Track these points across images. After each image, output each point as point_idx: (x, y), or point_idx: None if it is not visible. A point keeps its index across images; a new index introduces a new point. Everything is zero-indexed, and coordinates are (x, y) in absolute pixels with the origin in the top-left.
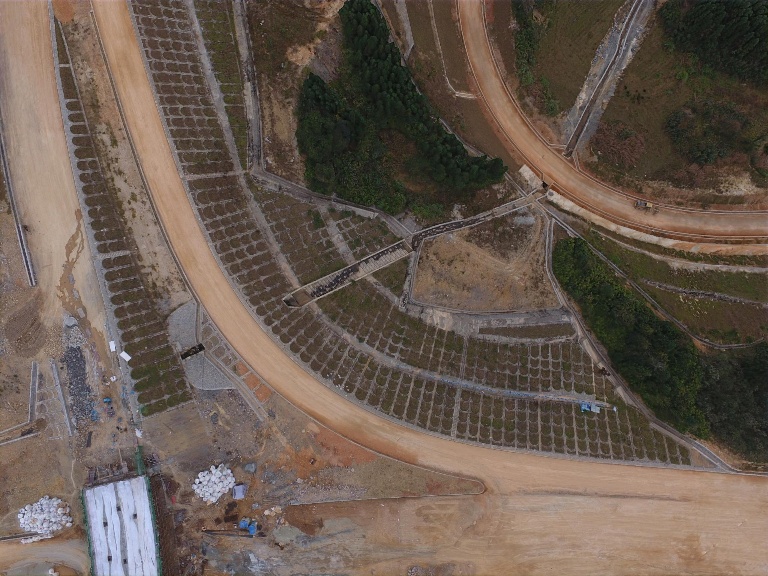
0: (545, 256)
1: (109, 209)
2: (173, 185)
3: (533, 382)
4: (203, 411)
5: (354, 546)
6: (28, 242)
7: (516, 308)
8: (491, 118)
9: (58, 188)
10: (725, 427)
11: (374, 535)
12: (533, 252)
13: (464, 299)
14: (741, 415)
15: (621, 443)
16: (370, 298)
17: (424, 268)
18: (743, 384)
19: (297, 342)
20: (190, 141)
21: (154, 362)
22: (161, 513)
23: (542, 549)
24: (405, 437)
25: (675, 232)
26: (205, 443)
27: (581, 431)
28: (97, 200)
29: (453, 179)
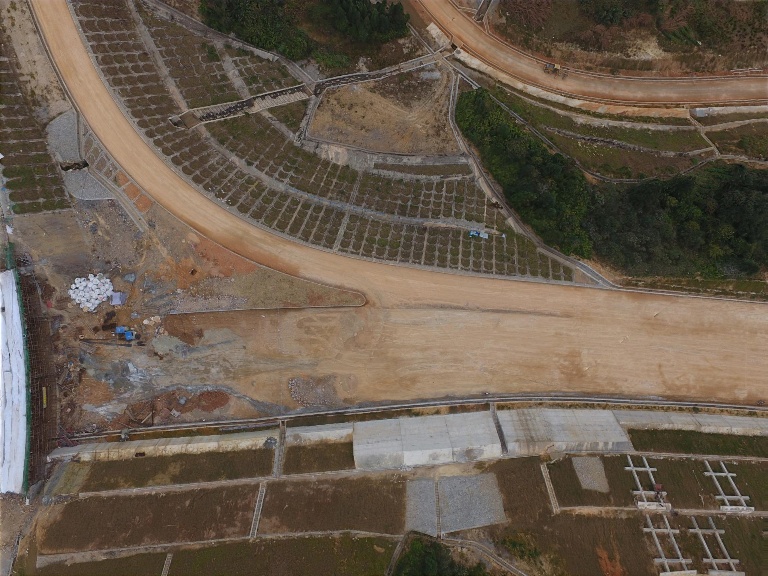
0: (449, 107)
1: None
2: None
3: (423, 210)
4: (82, 221)
5: (234, 357)
6: None
7: (416, 152)
8: None
9: None
10: (606, 243)
11: (255, 346)
12: (437, 103)
13: (360, 137)
14: (623, 233)
15: (505, 262)
16: (264, 131)
17: (323, 110)
18: (627, 207)
19: (180, 156)
20: None
21: (30, 166)
22: (33, 313)
23: (424, 363)
24: (287, 250)
25: (584, 96)
26: (83, 251)
27: (466, 251)
28: None
29: (356, 29)
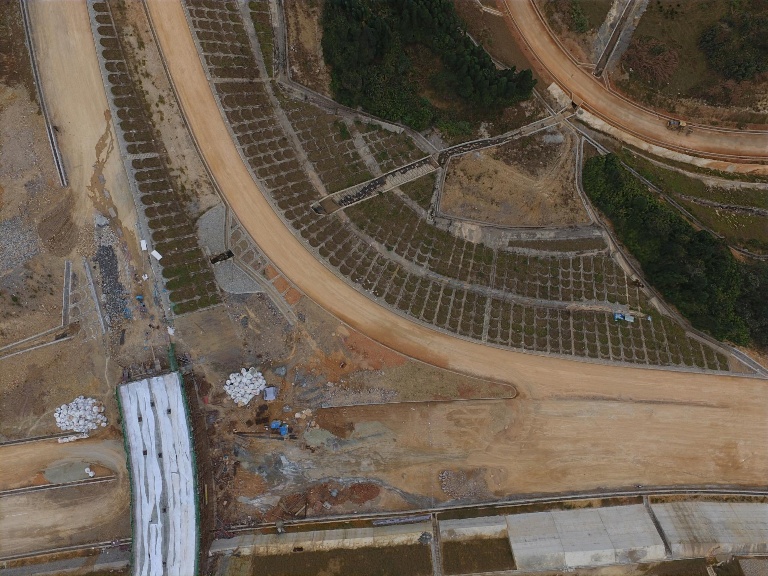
0: (575, 173)
1: (137, 111)
2: (200, 88)
3: (565, 292)
4: (233, 314)
5: (385, 450)
6: (59, 143)
7: (546, 224)
8: (518, 36)
9: (87, 89)
10: (766, 332)
11: (405, 439)
12: (563, 169)
13: (493, 212)
14: None
15: (656, 350)
16: (398, 210)
17: (451, 183)
18: None
19: (326, 247)
20: (216, 44)
21: (184, 263)
22: (194, 411)
23: (575, 455)
24: (435, 341)
25: (709, 153)
26: (236, 346)
27: (615, 338)
28: (125, 101)
29: (480, 95)
